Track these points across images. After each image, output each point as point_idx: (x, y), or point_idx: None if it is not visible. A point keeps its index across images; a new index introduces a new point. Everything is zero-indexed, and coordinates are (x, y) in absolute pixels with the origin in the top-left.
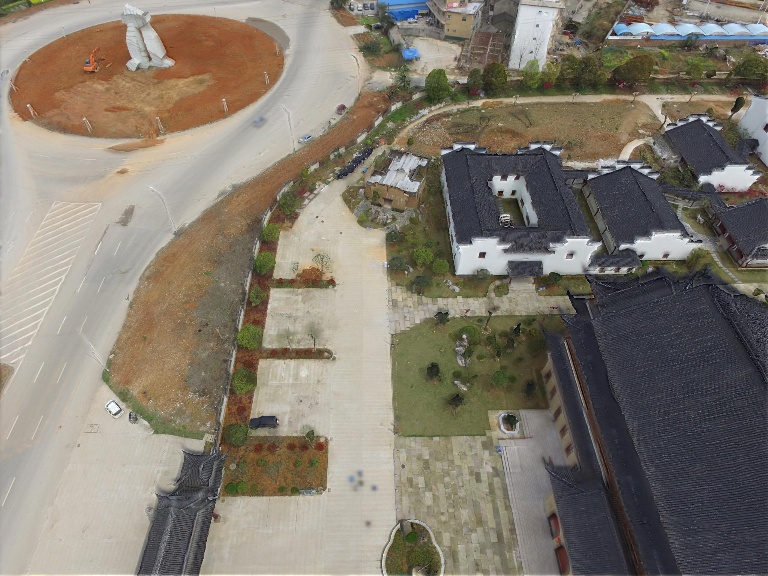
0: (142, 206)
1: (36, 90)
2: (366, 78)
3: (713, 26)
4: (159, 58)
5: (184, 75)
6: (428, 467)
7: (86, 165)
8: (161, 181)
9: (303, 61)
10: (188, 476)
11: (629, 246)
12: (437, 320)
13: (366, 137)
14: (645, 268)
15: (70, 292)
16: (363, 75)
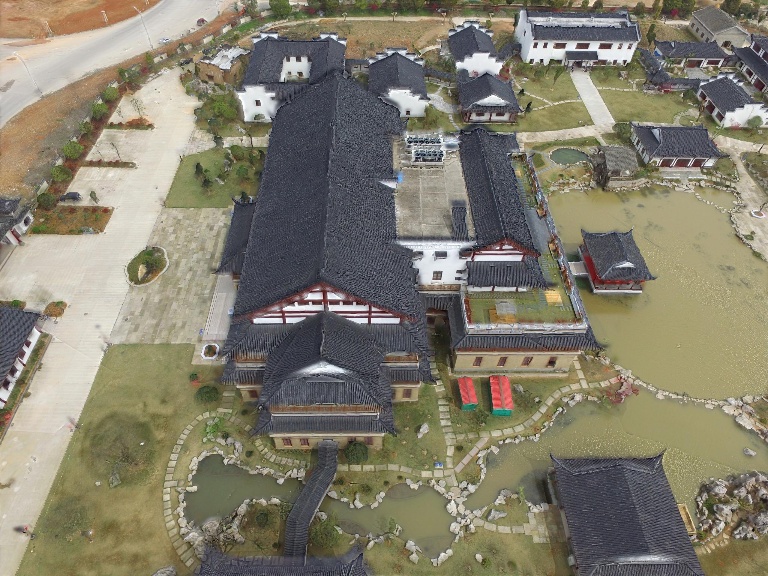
0: (21, 80)
1: None
2: (232, 3)
3: None
4: None
5: None
6: (179, 223)
7: None
8: (41, 65)
9: None
10: None
11: None
12: (216, 144)
13: (213, 39)
14: None
15: None
16: (230, 0)
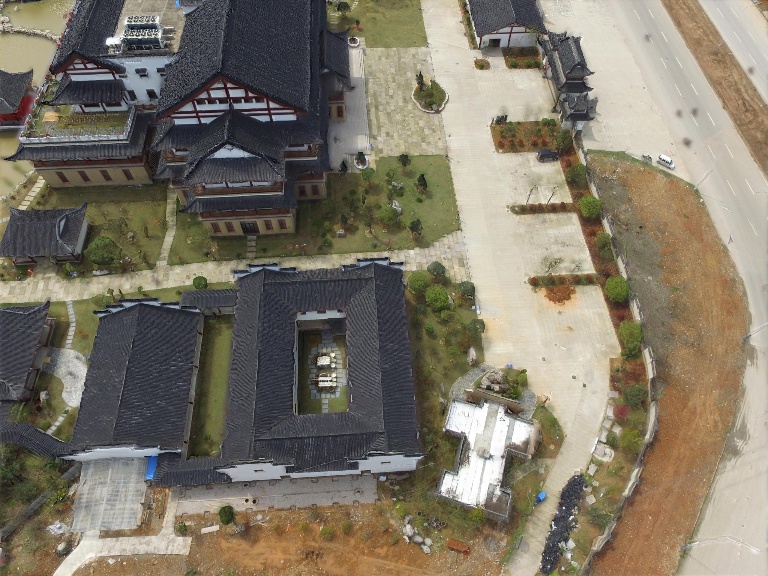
0: None
1: None
2: None
3: None
4: None
5: None
6: (422, 139)
7: None
8: None
9: None
10: None
11: None
12: None
13: None
14: None
15: None
16: None
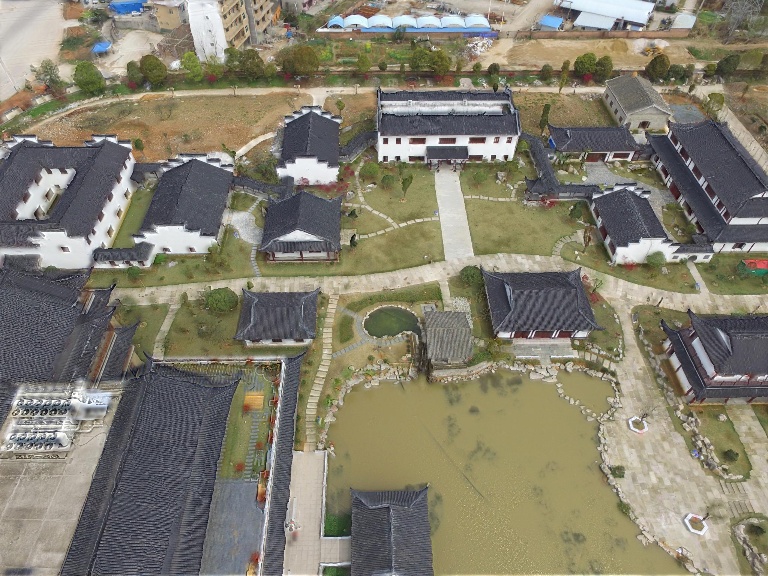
0: None
1: None
2: None
3: (429, 18)
4: None
5: None
6: None
7: None
8: None
9: None
10: None
11: (143, 239)
12: None
13: None
14: (168, 261)
15: None
16: None
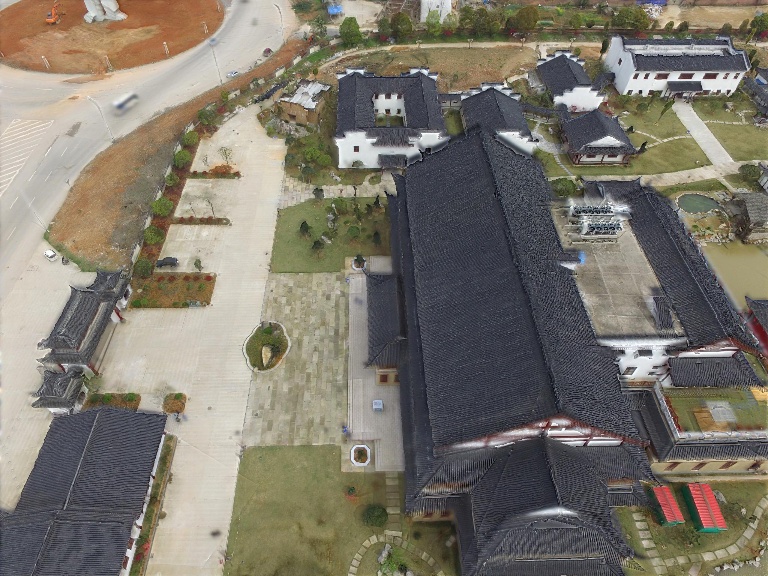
0: (88, 123)
1: (4, 37)
2: (294, 29)
3: None
4: (112, 11)
5: (134, 26)
6: (291, 291)
7: (43, 93)
8: (106, 105)
9: (241, 16)
10: (98, 283)
11: None
12: (315, 196)
13: (284, 72)
14: None
15: (22, 181)
16: (292, 27)
